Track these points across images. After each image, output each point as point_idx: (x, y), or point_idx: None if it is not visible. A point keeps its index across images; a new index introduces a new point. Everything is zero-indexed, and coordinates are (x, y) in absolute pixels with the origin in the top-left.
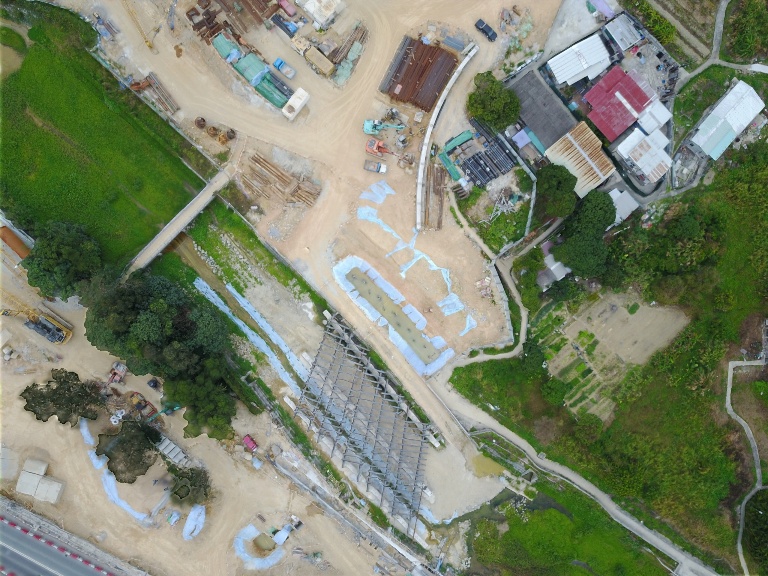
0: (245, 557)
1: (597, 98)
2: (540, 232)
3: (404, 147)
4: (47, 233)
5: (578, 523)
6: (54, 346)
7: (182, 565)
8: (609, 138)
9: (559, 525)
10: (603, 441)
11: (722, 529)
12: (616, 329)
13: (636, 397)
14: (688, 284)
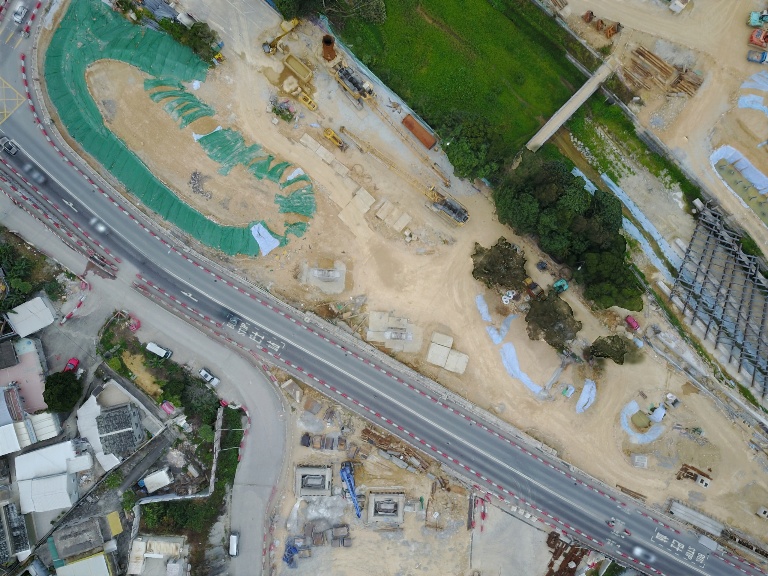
0: (629, 431)
1: None
2: None
3: None
4: (446, 122)
5: None
6: (449, 230)
7: (574, 437)
8: None
9: None
10: None
11: None
12: None
13: None
14: None
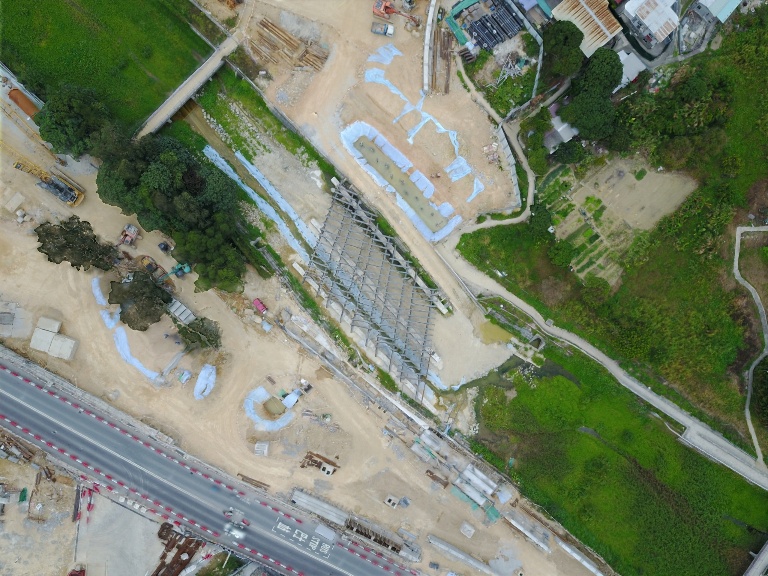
0: (255, 418)
1: None
2: (547, 96)
3: (411, 8)
4: None
5: (586, 390)
6: (66, 210)
7: (193, 424)
8: None
9: (567, 391)
10: (610, 305)
11: (730, 393)
12: (623, 195)
13: (643, 261)
14: (695, 145)
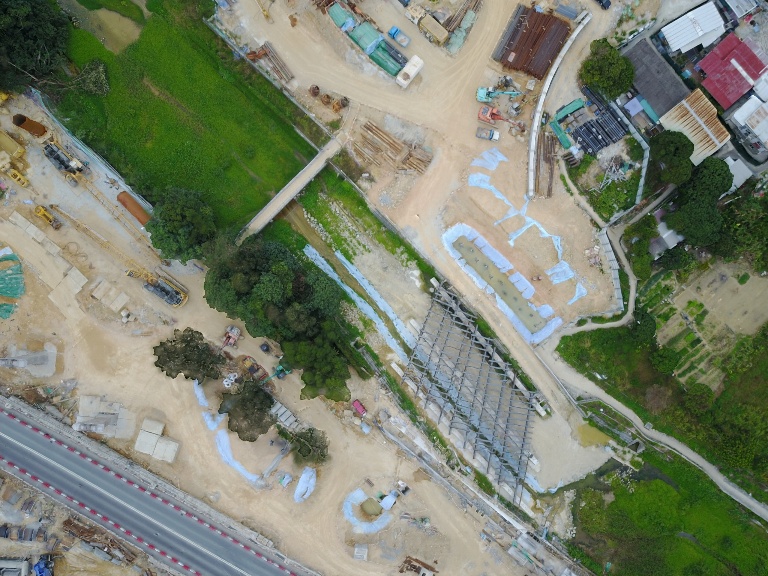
0: (354, 521)
1: (712, 65)
2: (650, 201)
3: (517, 114)
4: (165, 198)
5: (685, 495)
6: (169, 310)
7: (293, 527)
8: (723, 106)
9: (666, 496)
10: (713, 412)
11: None
12: (726, 299)
13: (747, 368)
14: None
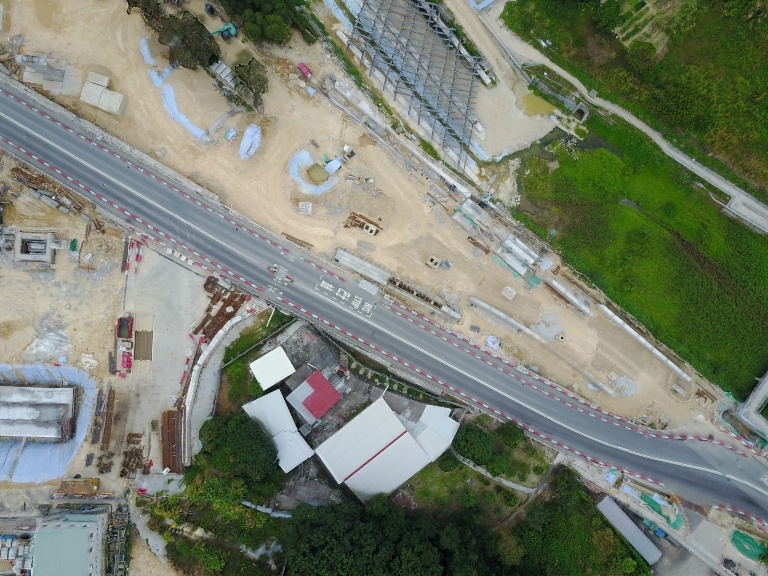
0: (299, 181)
1: None
2: None
3: None
4: None
5: (629, 162)
6: None
7: (239, 183)
8: None
9: (610, 163)
10: (656, 72)
11: None
12: None
13: (690, 27)
14: None
